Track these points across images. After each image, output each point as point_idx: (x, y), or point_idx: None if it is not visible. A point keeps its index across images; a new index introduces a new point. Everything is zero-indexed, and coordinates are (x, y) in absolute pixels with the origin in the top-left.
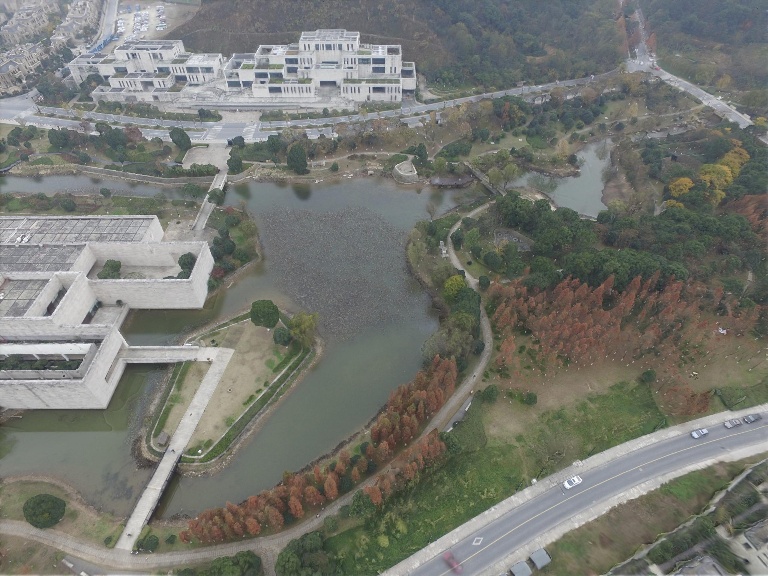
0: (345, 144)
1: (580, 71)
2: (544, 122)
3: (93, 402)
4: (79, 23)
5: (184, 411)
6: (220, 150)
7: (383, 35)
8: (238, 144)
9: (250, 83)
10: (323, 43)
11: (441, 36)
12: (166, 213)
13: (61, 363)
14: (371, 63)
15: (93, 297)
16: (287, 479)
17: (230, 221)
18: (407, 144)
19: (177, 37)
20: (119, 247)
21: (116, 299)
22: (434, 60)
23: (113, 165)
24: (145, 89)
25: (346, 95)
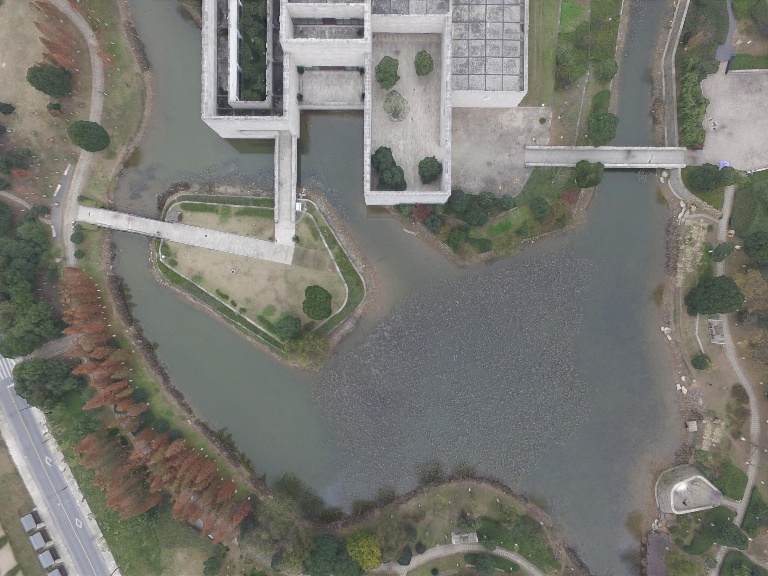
0: None
1: None
2: None
3: None
4: None
5: (210, 227)
6: None
7: None
8: None
9: None
10: None
11: None
12: (570, 92)
13: None
14: None
15: (360, 63)
16: None
17: (534, 207)
18: None
19: None
20: None
21: None
22: None
23: None
24: None
25: None
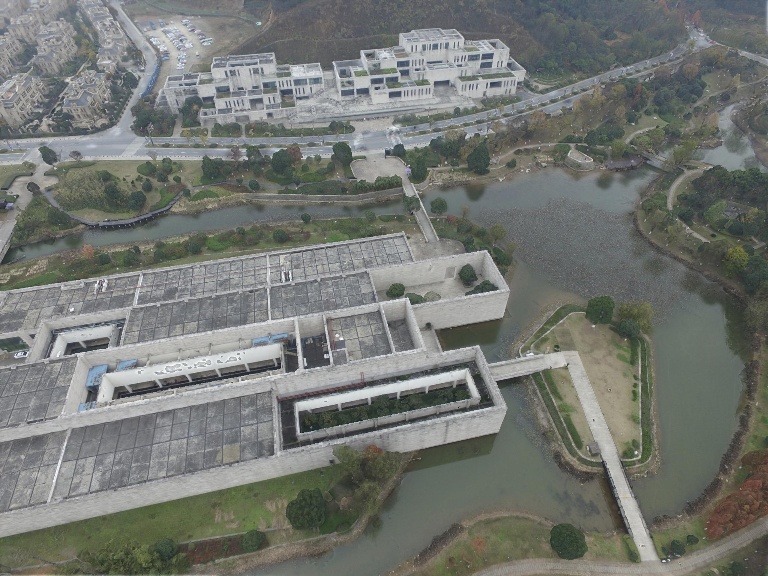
0: (510, 140)
1: (658, 50)
2: (666, 100)
3: (493, 428)
4: (121, 44)
5: (584, 418)
6: (381, 161)
7: (468, 31)
8: (401, 152)
9: (363, 90)
10: (430, 43)
11: (528, 27)
12: (386, 230)
13: (421, 396)
14: (480, 59)
15: None
16: (763, 458)
17: (465, 228)
18: (559, 134)
19: (252, 50)
20: (400, 269)
21: (425, 322)
22: (534, 51)
23: (287, 189)
24: (252, 107)
25: (464, 93)
